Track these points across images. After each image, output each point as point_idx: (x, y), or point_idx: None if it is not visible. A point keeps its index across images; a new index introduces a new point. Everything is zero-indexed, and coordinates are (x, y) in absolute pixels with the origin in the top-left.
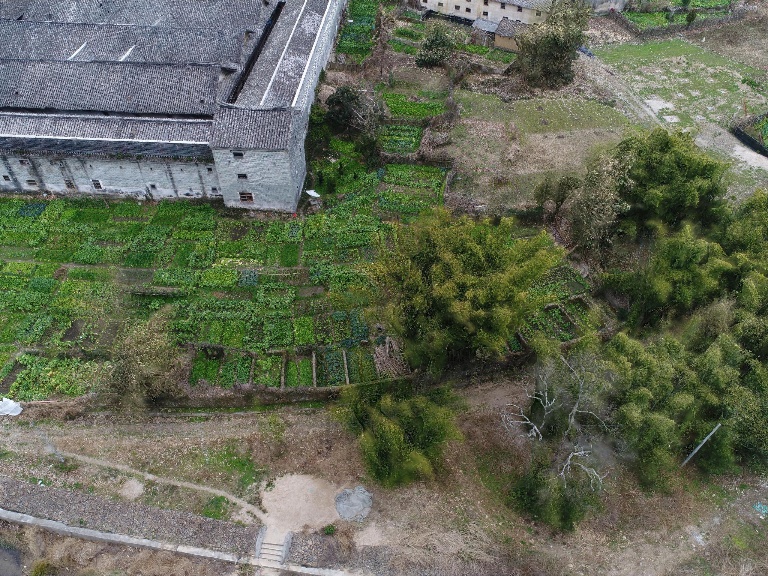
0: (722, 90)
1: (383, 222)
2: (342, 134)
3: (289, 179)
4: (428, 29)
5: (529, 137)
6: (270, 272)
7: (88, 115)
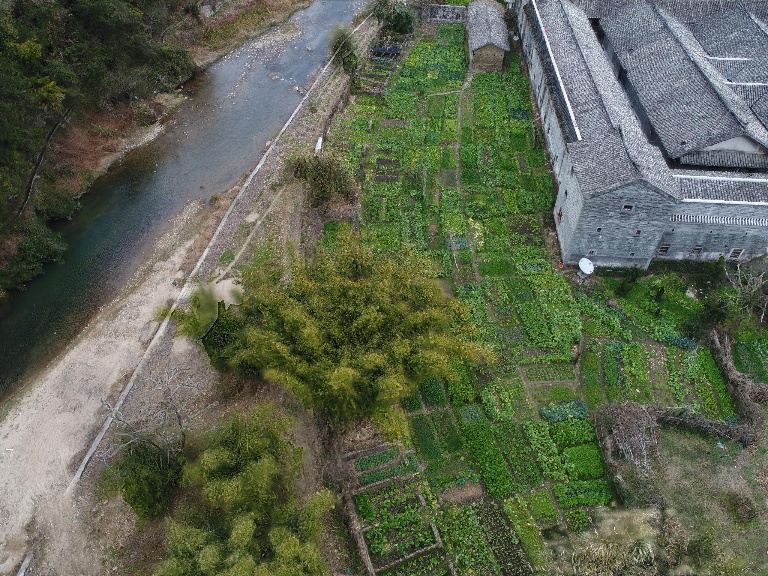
0: None
1: (575, 346)
2: None
3: (575, 227)
4: None
5: None
6: (464, 255)
7: (621, 89)
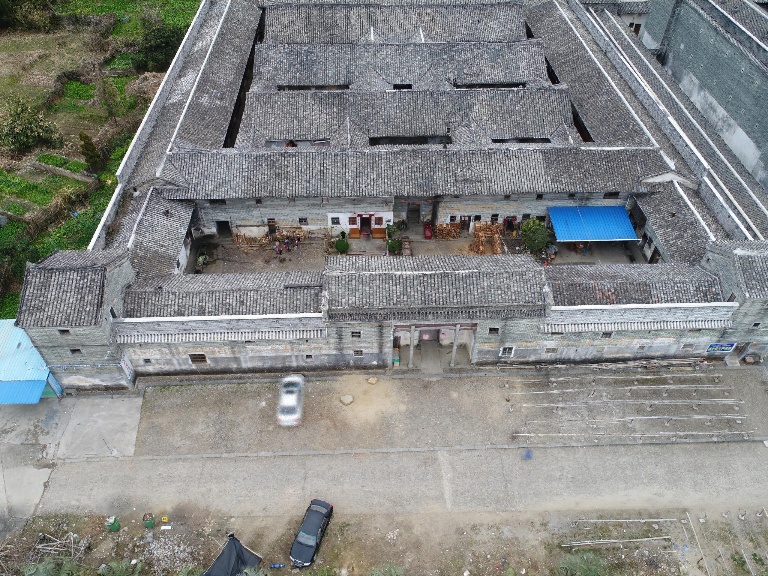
0: None
1: None
2: None
3: None
4: (3, 206)
5: (7, 73)
6: None
7: None
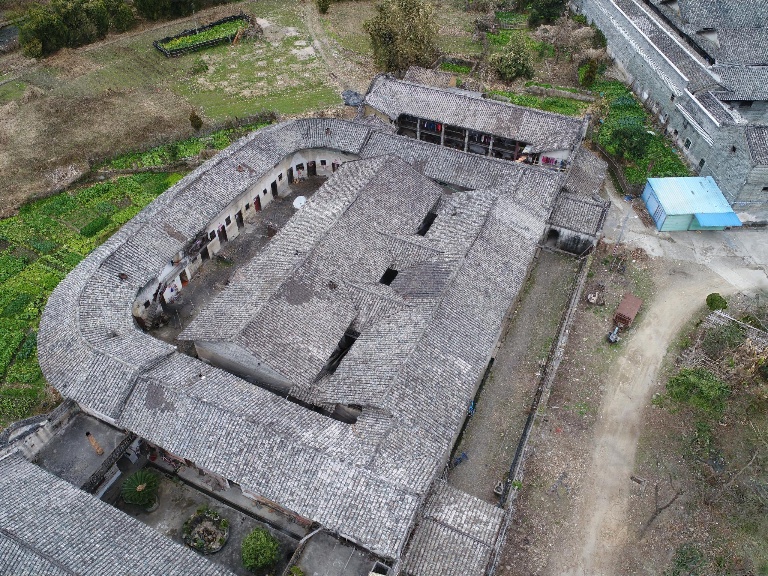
0: (232, 67)
1: None
2: (553, 22)
3: None
4: None
5: None
6: None
7: None
